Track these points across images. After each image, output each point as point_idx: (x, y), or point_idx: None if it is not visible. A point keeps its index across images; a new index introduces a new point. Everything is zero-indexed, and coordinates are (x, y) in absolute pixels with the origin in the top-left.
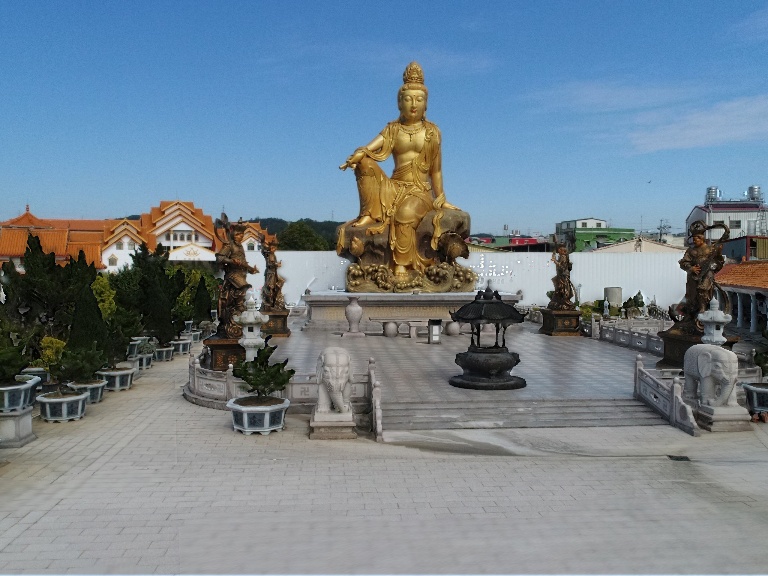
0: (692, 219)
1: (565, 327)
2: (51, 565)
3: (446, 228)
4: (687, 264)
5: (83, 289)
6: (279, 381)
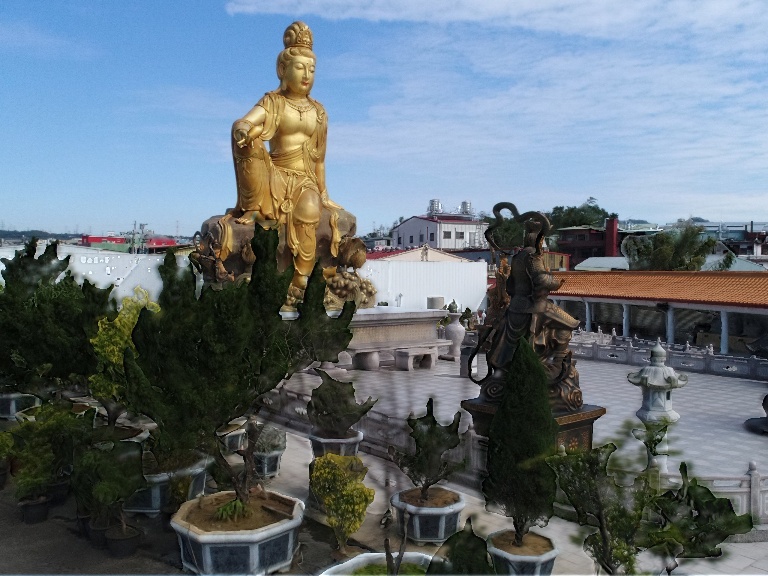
0: (404, 228)
1: None
2: None
3: (344, 231)
4: None
5: (525, 349)
6: None
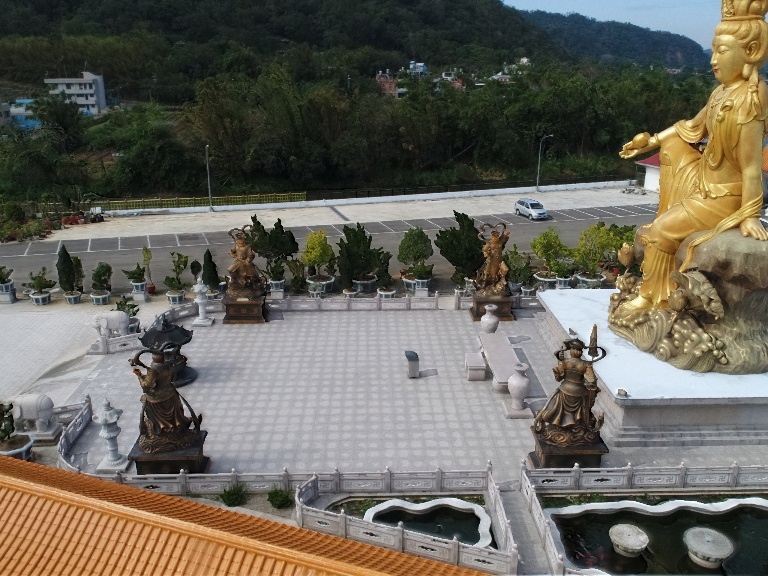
0: None
1: None
2: (8, 321)
3: (695, 263)
4: None
5: None
6: None
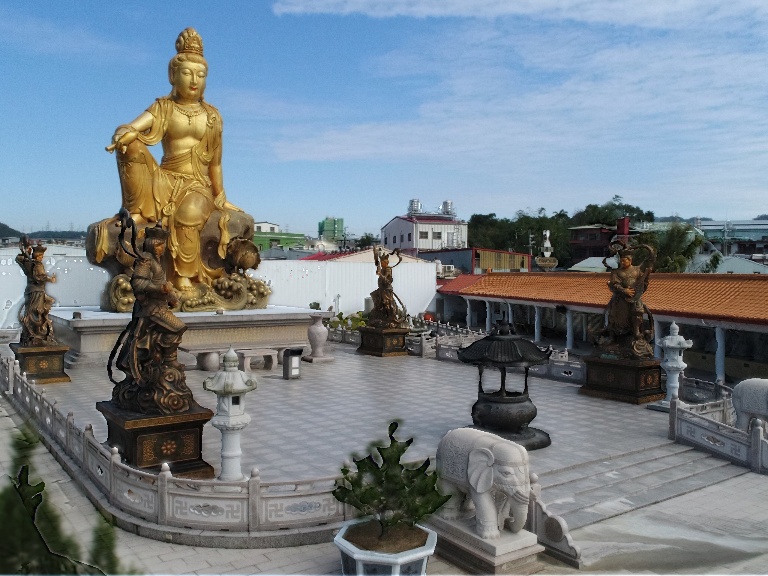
0: (390, 228)
1: (393, 346)
2: None
3: (234, 233)
4: (619, 286)
5: None
6: (441, 500)
